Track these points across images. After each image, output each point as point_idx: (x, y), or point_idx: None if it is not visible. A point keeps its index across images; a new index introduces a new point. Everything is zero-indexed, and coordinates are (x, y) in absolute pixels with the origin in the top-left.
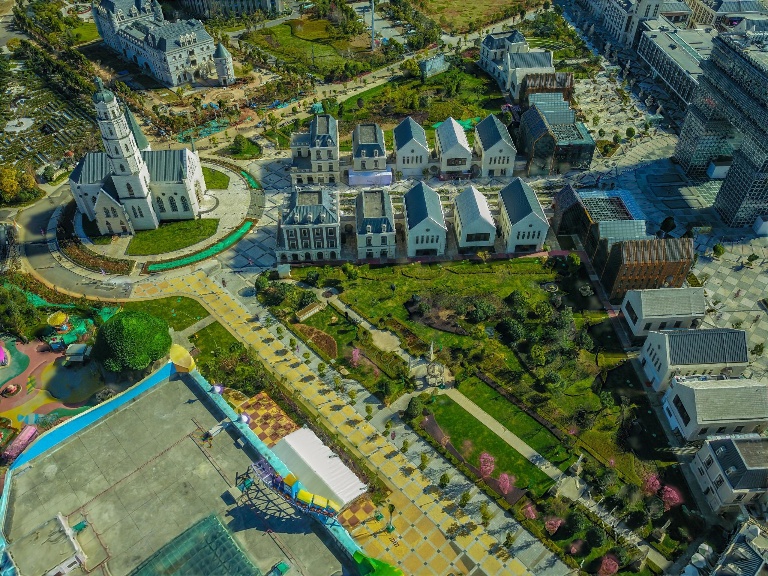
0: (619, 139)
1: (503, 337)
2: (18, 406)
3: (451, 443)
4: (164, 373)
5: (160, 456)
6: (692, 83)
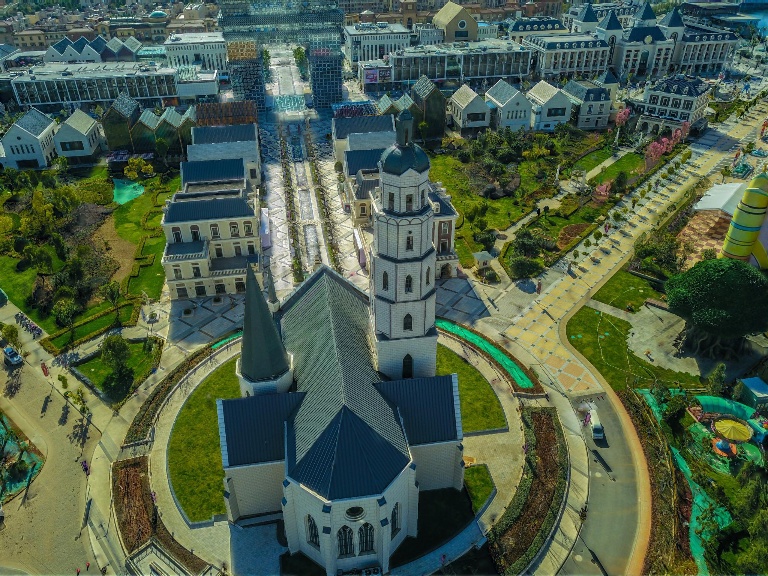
0: None
1: (514, 161)
2: None
3: None
4: None
5: None
6: (147, 78)
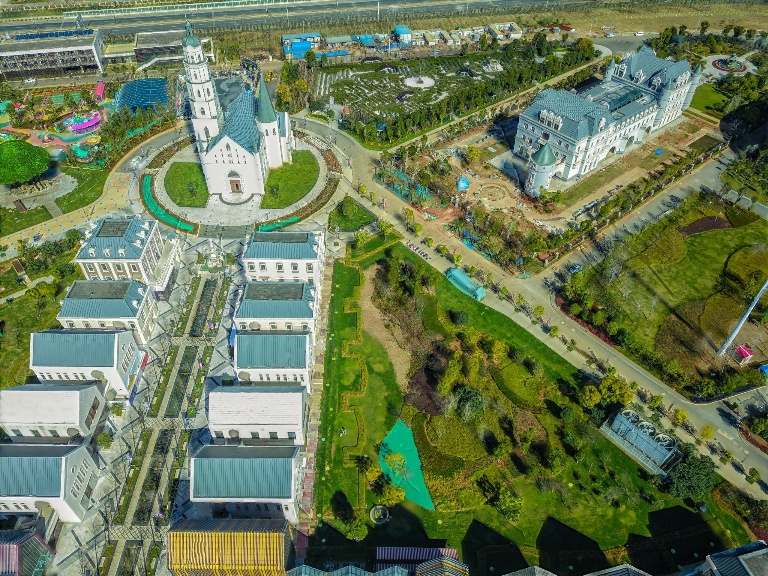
0: None
1: None
2: None
3: None
4: None
5: None
6: None
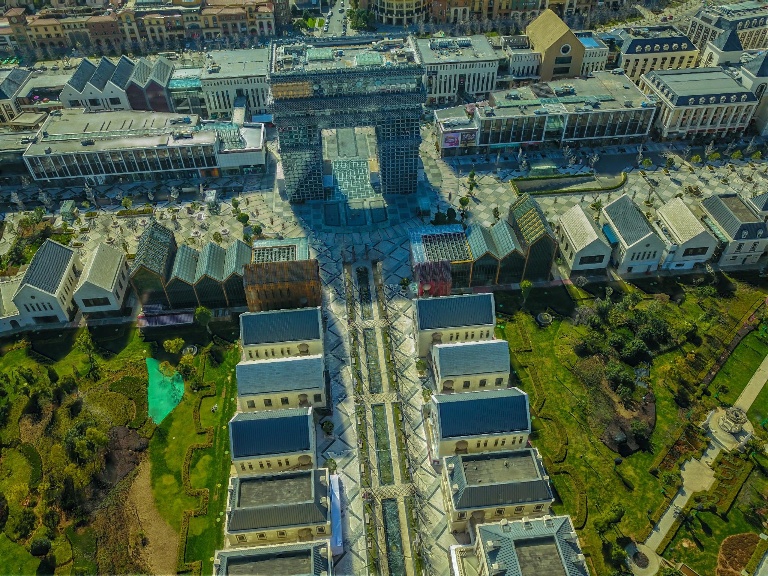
0: (260, 228)
1: (645, 361)
2: None
3: None
4: None
5: None
6: (181, 149)
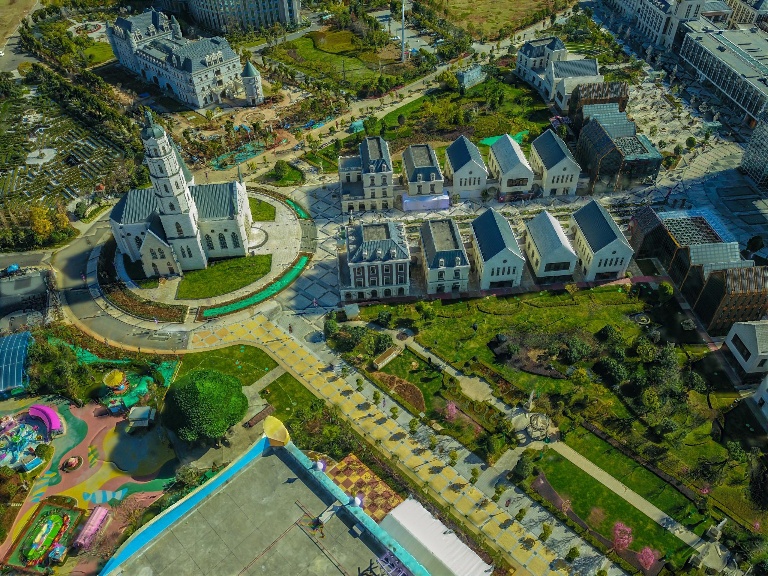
0: (681, 150)
1: (603, 379)
2: (82, 482)
3: (570, 507)
4: (258, 449)
5: (268, 551)
6: (750, 87)
